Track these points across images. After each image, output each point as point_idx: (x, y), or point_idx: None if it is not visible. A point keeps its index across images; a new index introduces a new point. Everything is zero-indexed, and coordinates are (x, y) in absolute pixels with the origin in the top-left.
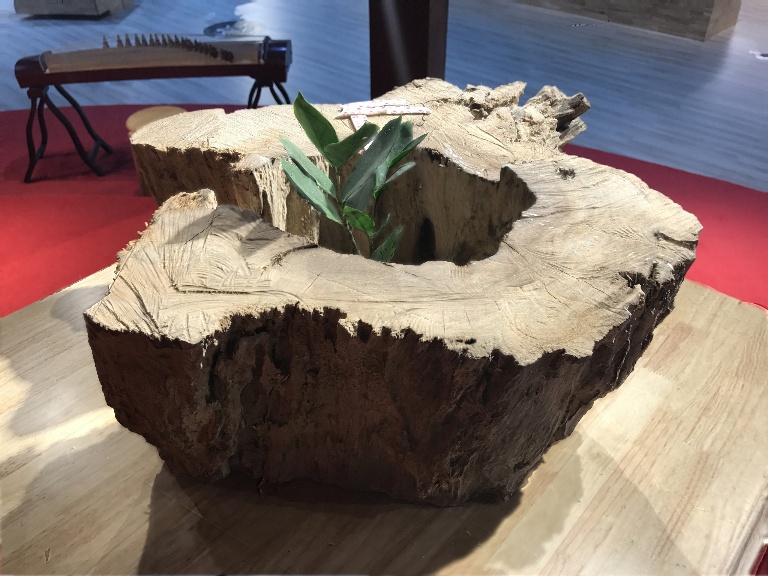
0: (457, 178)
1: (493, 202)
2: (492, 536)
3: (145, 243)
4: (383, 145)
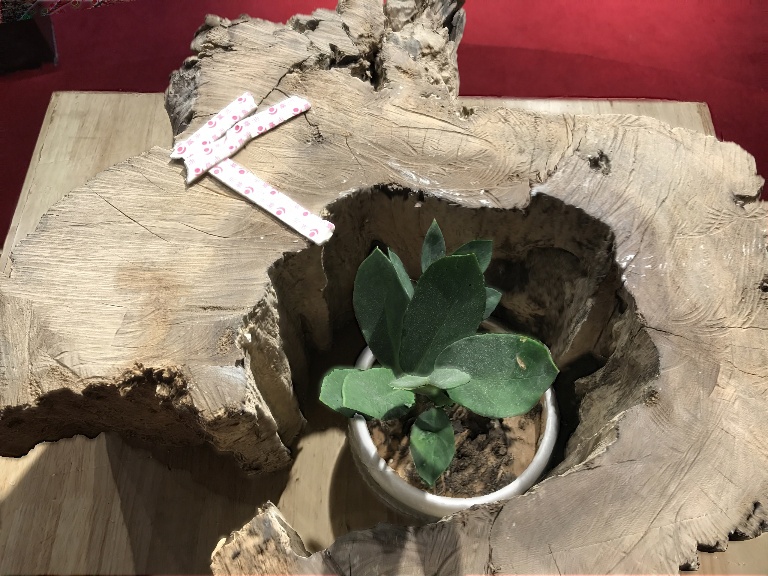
0: (448, 213)
1: (514, 226)
2: None
3: None
4: (447, 293)
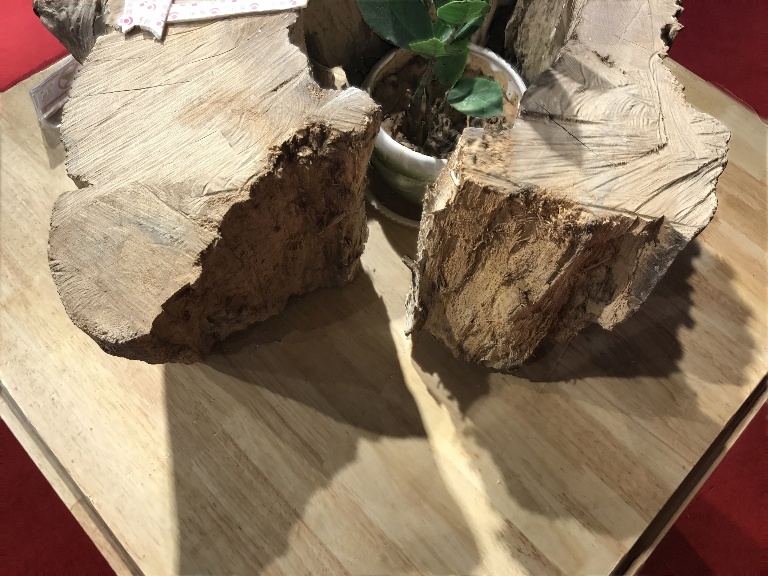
0: None
1: None
2: None
3: (577, 191)
4: None
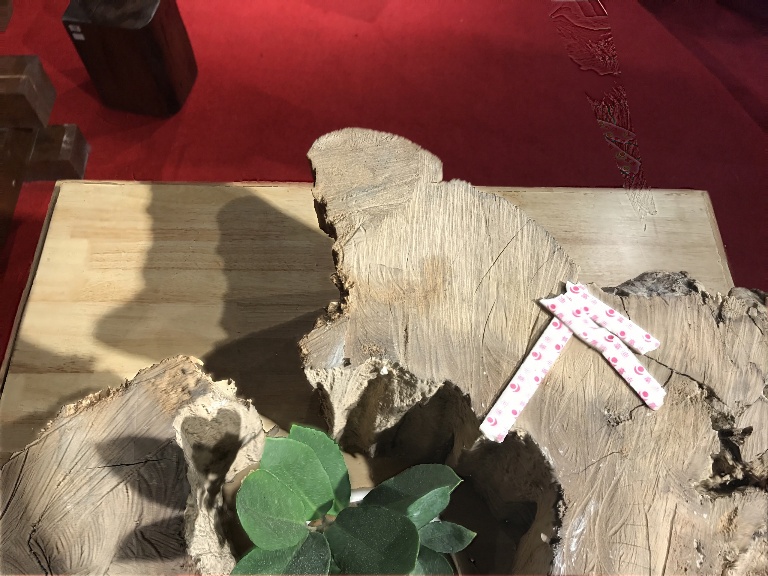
0: (542, 575)
1: None
2: None
3: (86, 421)
4: (392, 547)
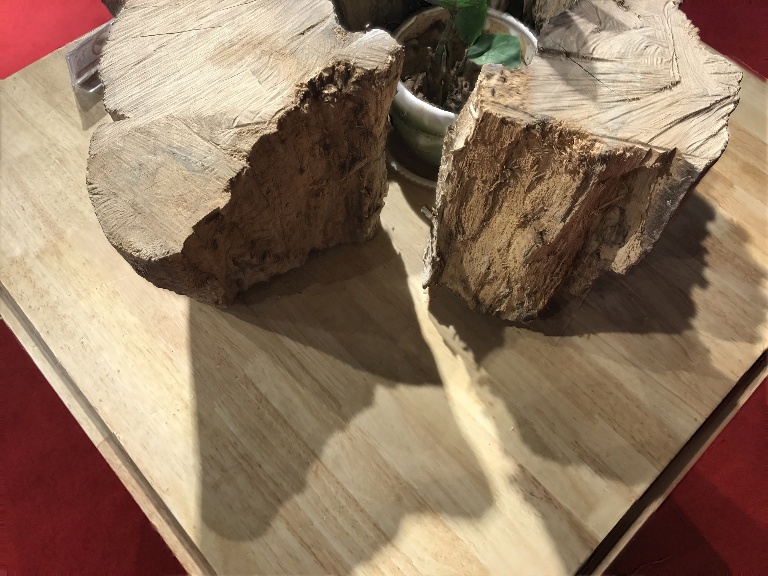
0: None
1: None
2: None
3: (592, 123)
4: None
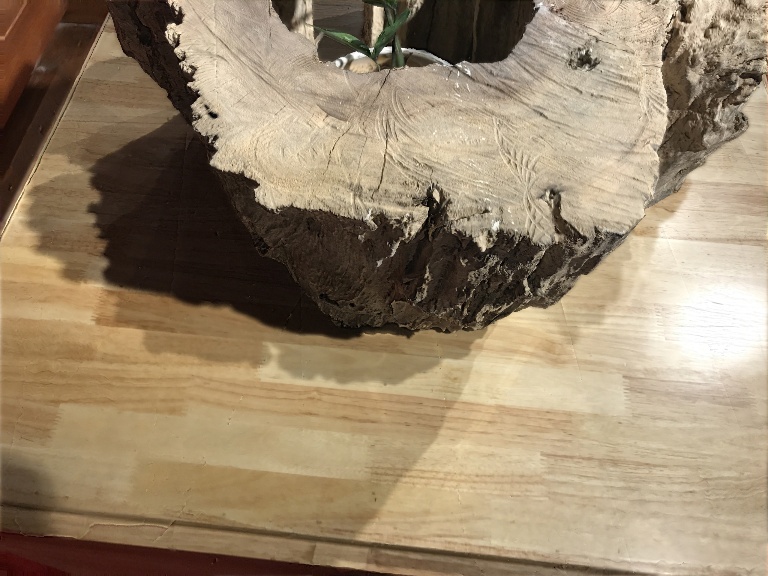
0: None
1: None
2: (299, 333)
3: None
4: None
